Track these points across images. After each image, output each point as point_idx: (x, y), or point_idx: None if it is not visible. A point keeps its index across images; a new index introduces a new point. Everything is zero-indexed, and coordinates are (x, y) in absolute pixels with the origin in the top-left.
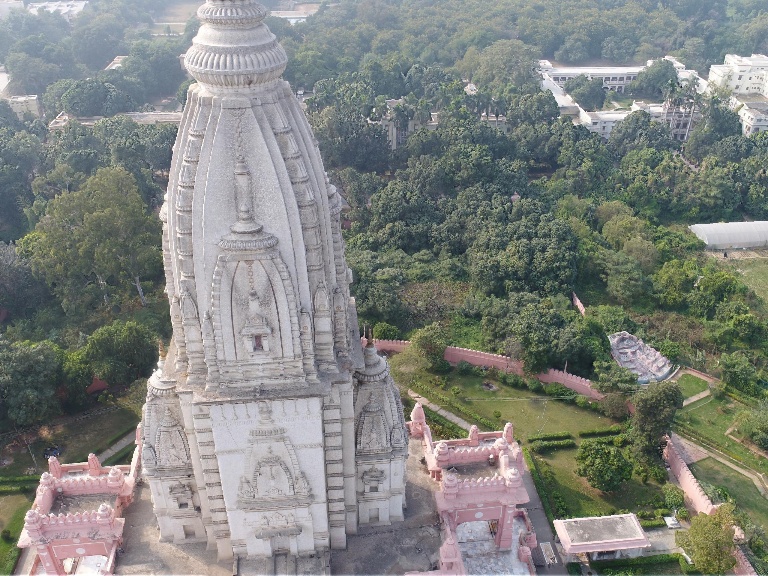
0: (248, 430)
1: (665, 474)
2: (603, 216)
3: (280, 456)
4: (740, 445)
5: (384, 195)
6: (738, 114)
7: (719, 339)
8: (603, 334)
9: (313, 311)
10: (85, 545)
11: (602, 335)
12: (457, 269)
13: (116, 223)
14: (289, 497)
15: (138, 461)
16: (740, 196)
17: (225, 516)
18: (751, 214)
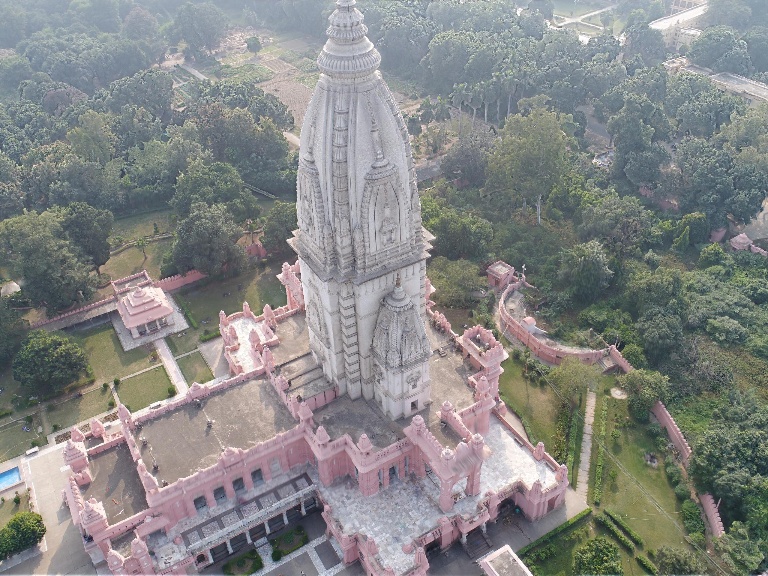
0: None
1: None
2: None
3: None
4: None
5: None
6: None
7: None
8: None
9: None
10: None
11: None
12: None
13: (521, 151)
14: None
15: None
16: None
17: None
18: None
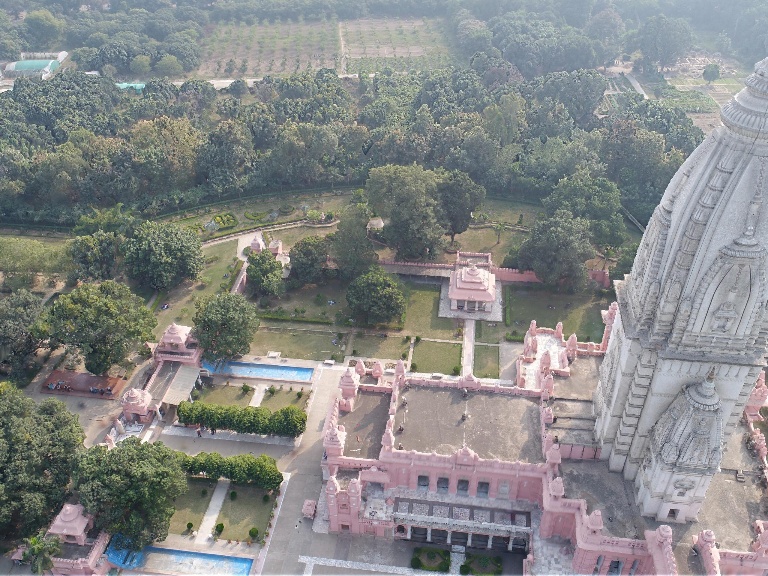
0: None
1: None
2: None
3: None
4: None
5: None
6: None
7: None
8: None
9: None
10: None
11: None
12: None
13: None
14: None
15: None
16: None
17: None
18: None
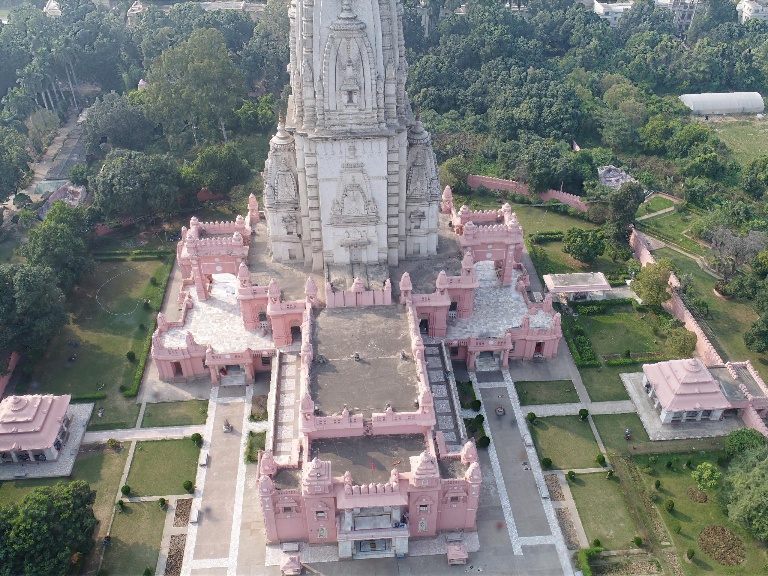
0: (340, 163)
1: (630, 254)
2: (605, 87)
3: (360, 184)
4: (691, 240)
5: (420, 65)
6: (739, 6)
7: (687, 172)
8: (593, 164)
9: (385, 79)
10: (222, 264)
11: (592, 165)
12: (479, 124)
13: (212, 71)
14: (364, 216)
15: (250, 222)
16: (726, 72)
17: (320, 235)
18: (736, 88)
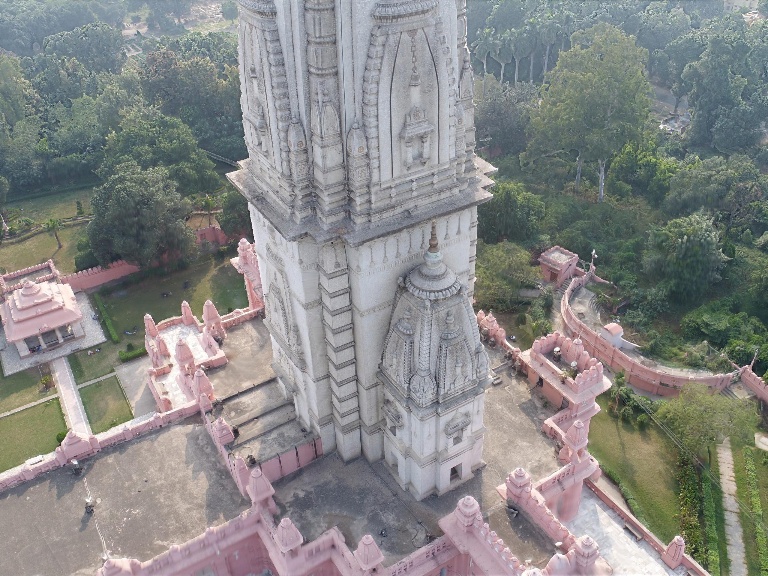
0: None
1: None
2: None
3: (281, 290)
4: None
5: None
6: None
7: None
8: None
9: None
10: None
11: None
12: None
13: (586, 91)
14: None
15: None
16: None
17: None
18: None
